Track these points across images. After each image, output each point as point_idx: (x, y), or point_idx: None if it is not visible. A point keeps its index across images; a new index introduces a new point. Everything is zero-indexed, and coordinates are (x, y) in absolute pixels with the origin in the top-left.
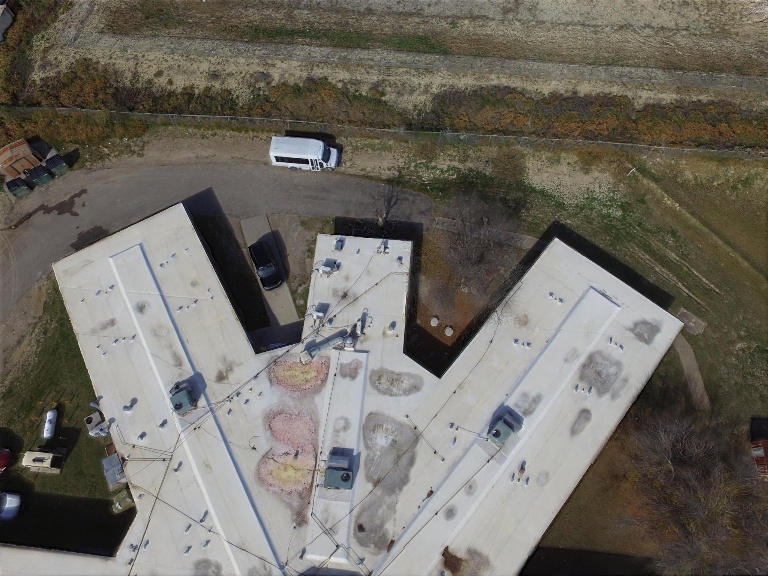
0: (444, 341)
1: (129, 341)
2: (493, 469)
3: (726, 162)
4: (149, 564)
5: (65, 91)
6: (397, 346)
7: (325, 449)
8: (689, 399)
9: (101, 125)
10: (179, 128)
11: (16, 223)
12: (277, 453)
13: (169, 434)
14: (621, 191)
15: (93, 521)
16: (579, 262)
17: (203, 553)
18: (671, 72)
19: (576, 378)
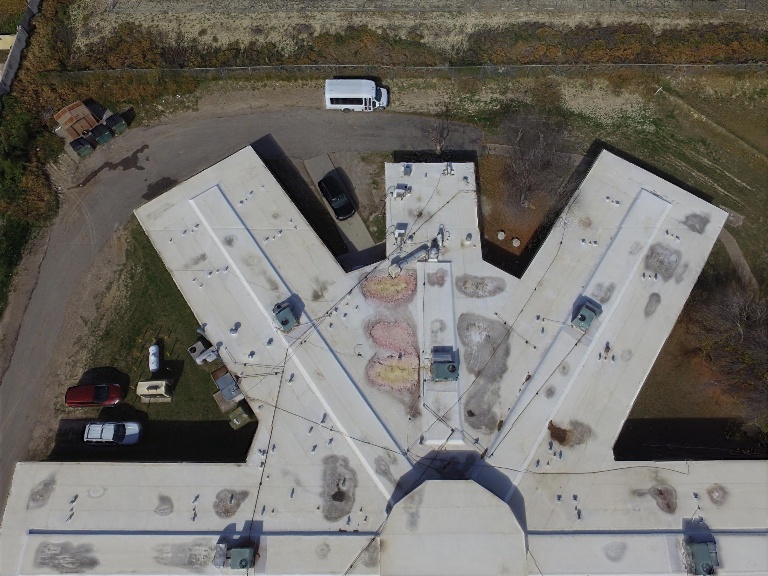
0: (513, 251)
1: (223, 272)
2: (581, 351)
3: (741, 76)
4: (279, 465)
5: (113, 54)
6: (476, 254)
7: (426, 348)
8: (738, 281)
9: (154, 84)
10: (229, 82)
11: (83, 181)
12: (382, 357)
13: (277, 351)
14: (651, 109)
15: (210, 441)
16: (628, 168)
17: (328, 450)
18: (682, 0)
19: (642, 267)
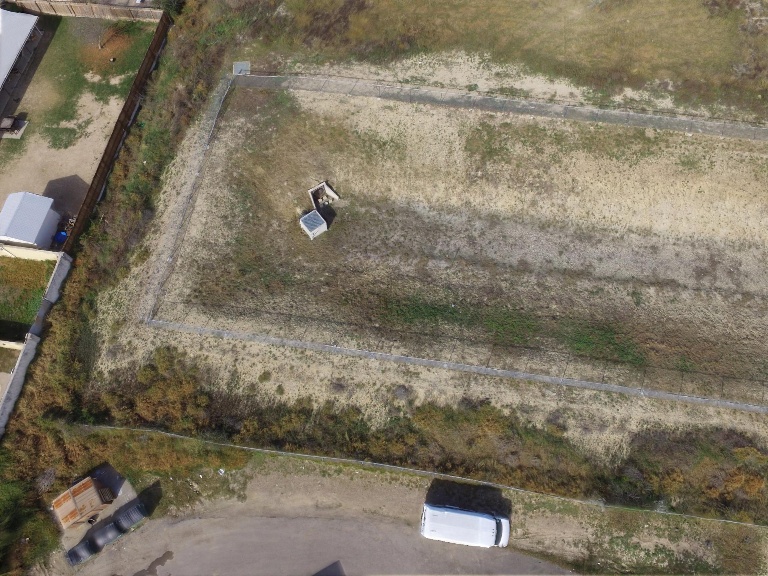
0: None
1: None
2: None
3: None
4: None
5: (143, 398)
6: None
7: None
8: None
9: (191, 454)
10: (292, 458)
11: None
12: None
13: None
14: None
15: None
16: None
17: None
18: None
19: None
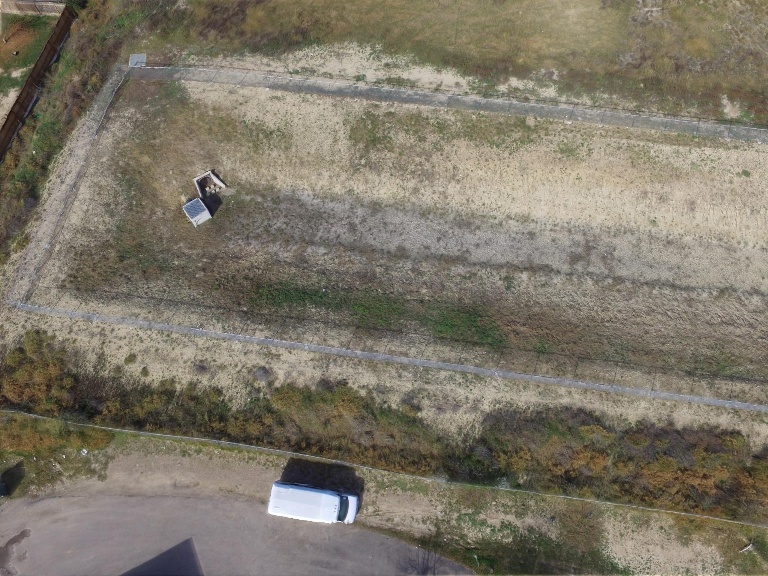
0: None
1: None
2: None
3: None
4: None
5: (10, 380)
6: None
7: None
8: None
9: (53, 435)
10: (154, 439)
11: None
12: None
13: None
14: None
15: None
16: None
17: None
18: None
19: None
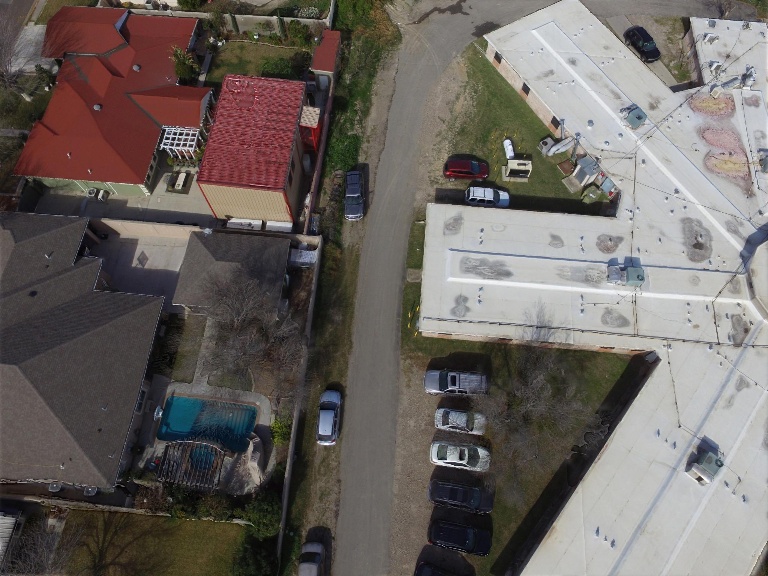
0: None
1: (571, 84)
2: None
3: None
4: (646, 221)
5: None
6: None
7: (753, 149)
8: None
9: None
10: None
11: (418, 20)
12: (716, 153)
13: (627, 142)
14: None
15: None
16: None
17: (684, 214)
18: None
19: None
